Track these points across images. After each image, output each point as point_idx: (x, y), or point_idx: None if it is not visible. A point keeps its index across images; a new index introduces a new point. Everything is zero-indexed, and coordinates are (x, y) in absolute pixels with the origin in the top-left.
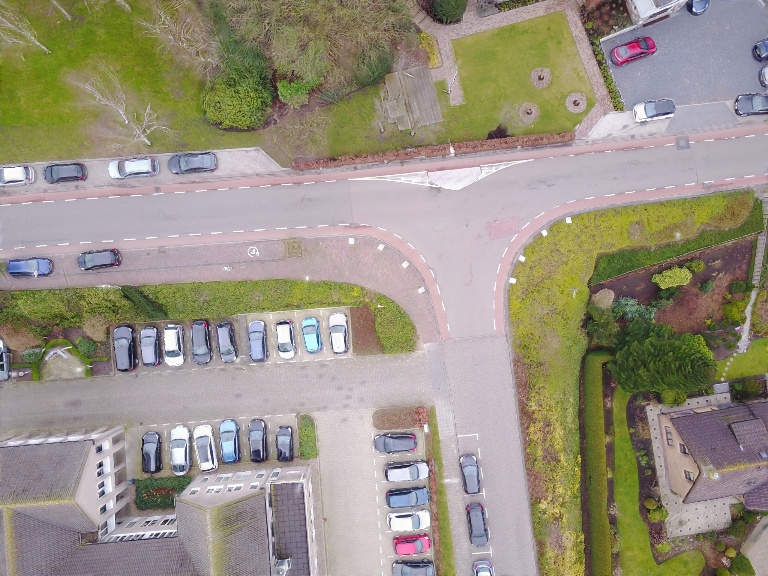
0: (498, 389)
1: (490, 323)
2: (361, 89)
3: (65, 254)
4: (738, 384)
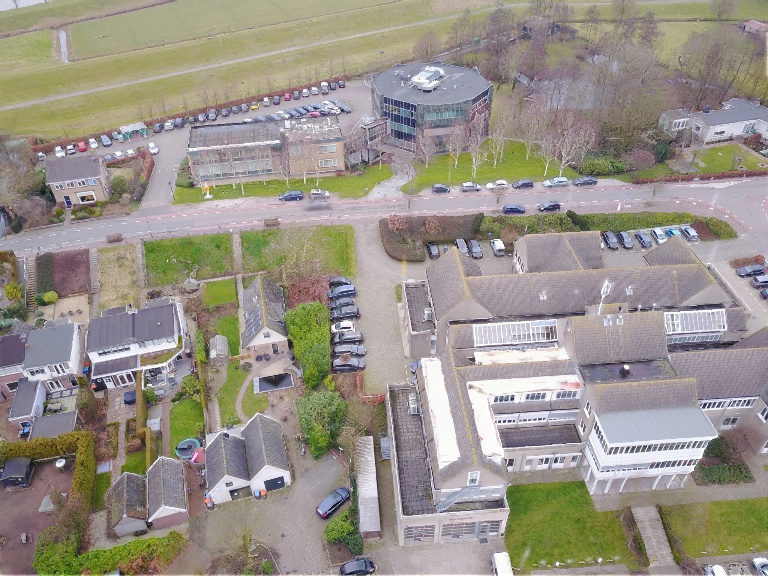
0: None
1: None
2: (654, 164)
3: (529, 208)
4: None
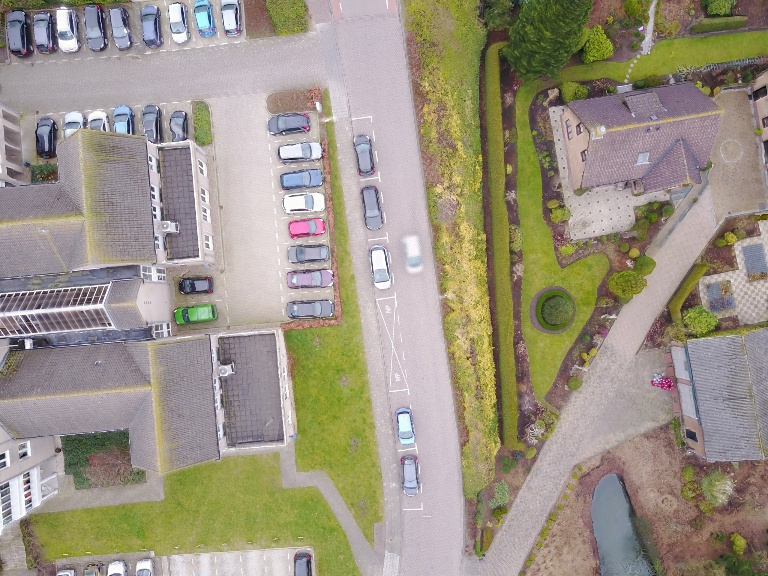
0: (392, 70)
1: (382, 2)
2: None
3: None
4: (640, 81)
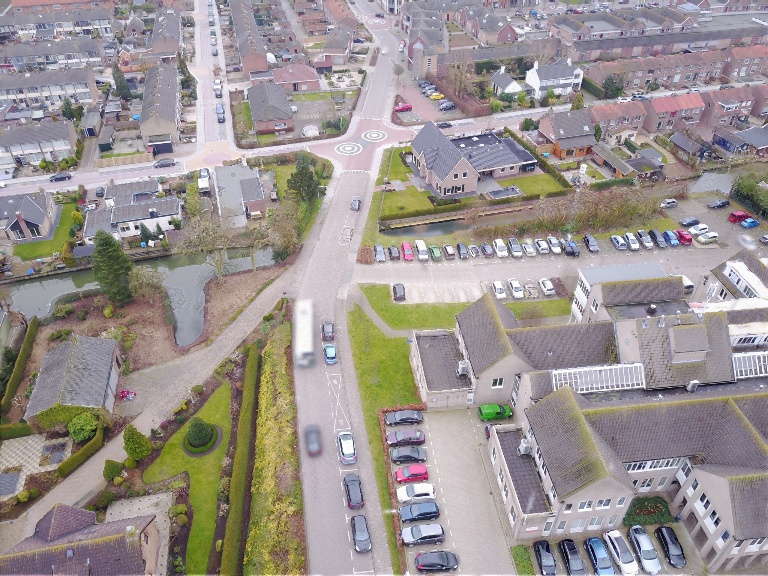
0: None
1: None
2: None
3: None
4: None
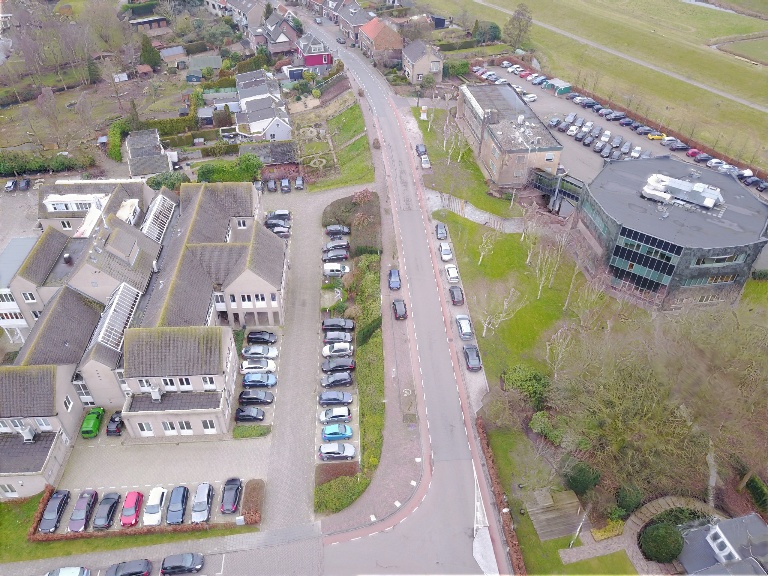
0: None
1: None
2: None
3: (403, 296)
4: None
